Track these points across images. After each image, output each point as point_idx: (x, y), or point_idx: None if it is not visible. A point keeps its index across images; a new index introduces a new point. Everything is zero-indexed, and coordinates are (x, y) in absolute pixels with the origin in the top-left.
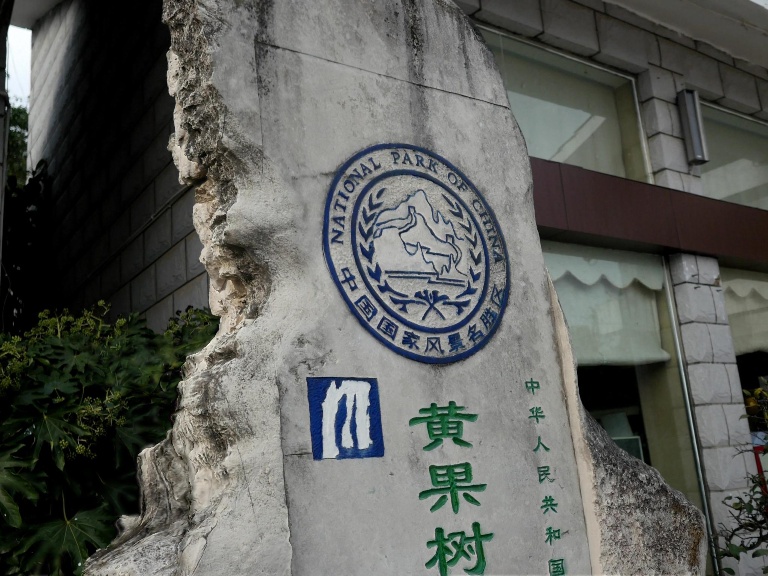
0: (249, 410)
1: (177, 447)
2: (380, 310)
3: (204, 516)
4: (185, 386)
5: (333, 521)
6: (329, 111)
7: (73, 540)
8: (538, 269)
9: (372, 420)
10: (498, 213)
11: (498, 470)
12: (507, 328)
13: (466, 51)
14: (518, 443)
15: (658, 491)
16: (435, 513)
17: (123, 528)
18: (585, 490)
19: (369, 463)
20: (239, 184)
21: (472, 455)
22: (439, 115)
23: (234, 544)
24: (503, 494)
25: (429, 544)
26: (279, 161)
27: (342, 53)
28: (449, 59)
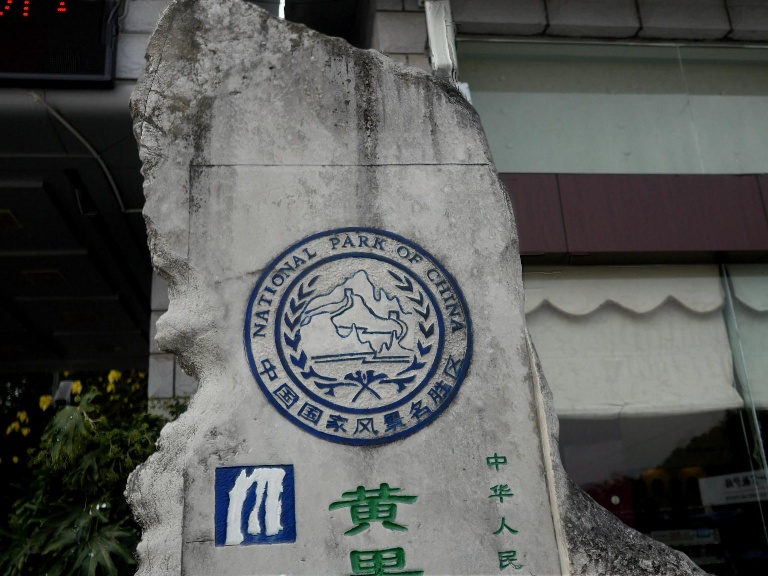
0: (157, 501)
1: None
2: (303, 396)
3: None
4: None
5: None
6: (262, 213)
7: None
8: (513, 332)
9: (284, 506)
10: (461, 279)
11: (441, 556)
12: (464, 401)
13: (434, 118)
14: (471, 526)
15: None
16: None
17: None
18: None
19: (277, 549)
20: (170, 295)
21: (407, 540)
22: (391, 191)
23: None
24: None
25: None
26: (203, 269)
27: (282, 155)
28: (410, 131)
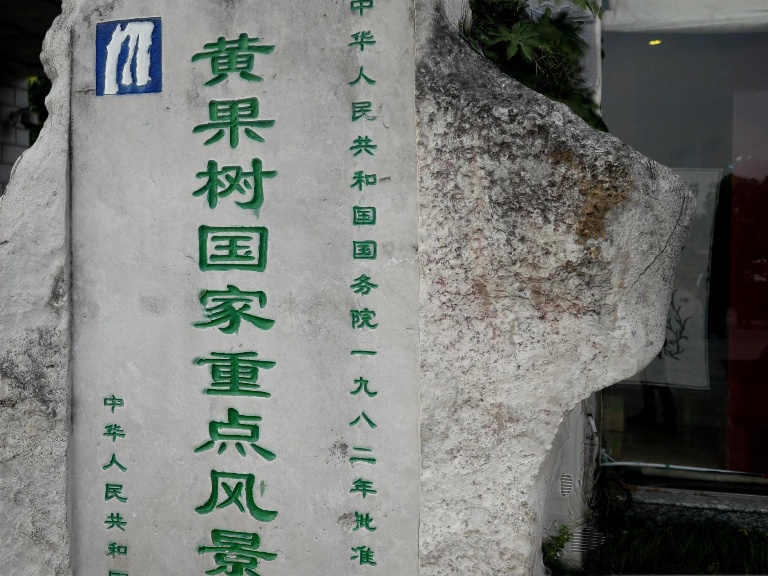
0: (55, 56)
1: None
2: None
3: None
4: None
5: (110, 147)
6: None
7: None
8: None
9: (153, 58)
10: None
11: (294, 105)
12: None
13: None
14: (327, 75)
15: (532, 132)
16: (210, 146)
17: None
18: None
19: (146, 98)
20: None
21: (262, 89)
22: None
23: (34, 159)
24: (296, 131)
25: (200, 174)
26: None
27: None
28: None
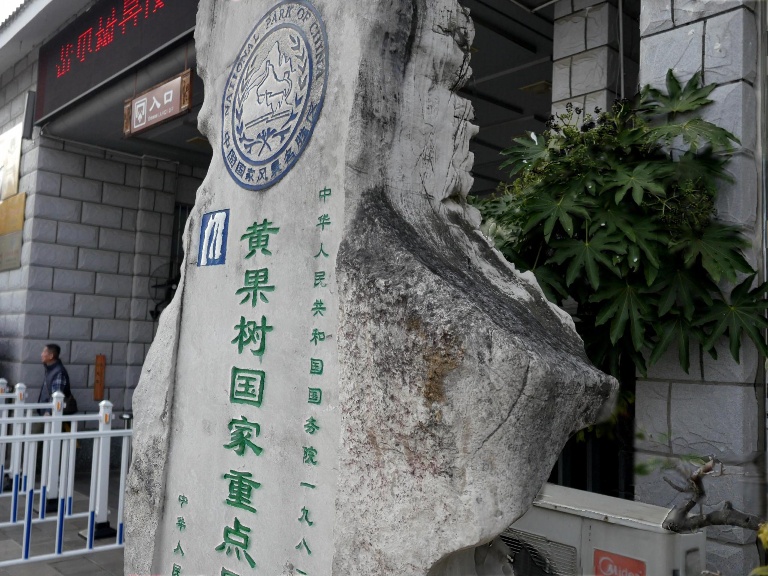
0: None
1: None
2: (239, 157)
3: None
4: None
5: None
6: (239, 14)
7: None
8: (353, 66)
9: (223, 239)
10: (329, 24)
11: (285, 274)
12: (314, 142)
13: None
14: (303, 250)
15: (399, 301)
16: (243, 305)
17: None
18: None
19: None
20: None
21: None
22: None
23: None
24: (285, 295)
25: None
26: None
27: None
28: None
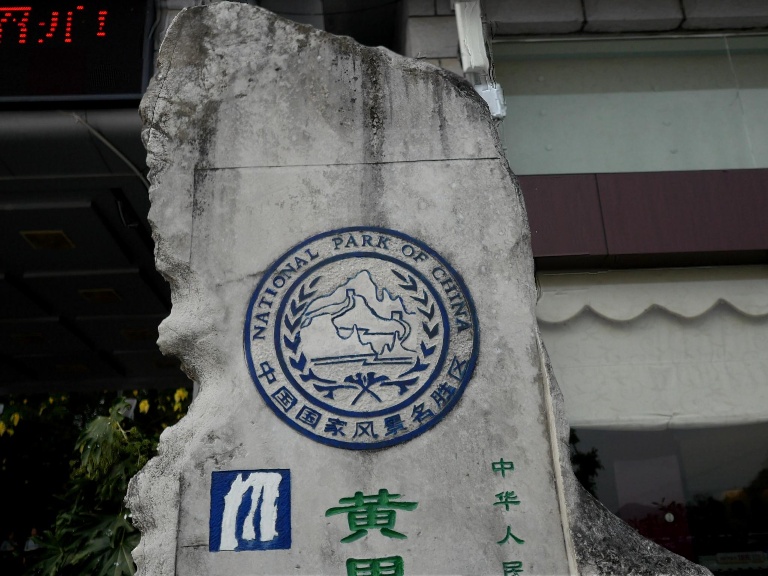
0: (154, 505)
1: None
2: (301, 399)
3: None
4: None
5: None
6: (265, 214)
7: None
8: (522, 331)
9: (280, 511)
10: (468, 277)
11: (441, 565)
12: (469, 403)
13: (443, 112)
14: (474, 534)
15: None
16: None
17: None
18: None
19: (271, 555)
20: (173, 299)
21: (406, 548)
22: (397, 188)
23: None
24: None
25: None
26: (205, 272)
27: (286, 156)
28: (418, 127)
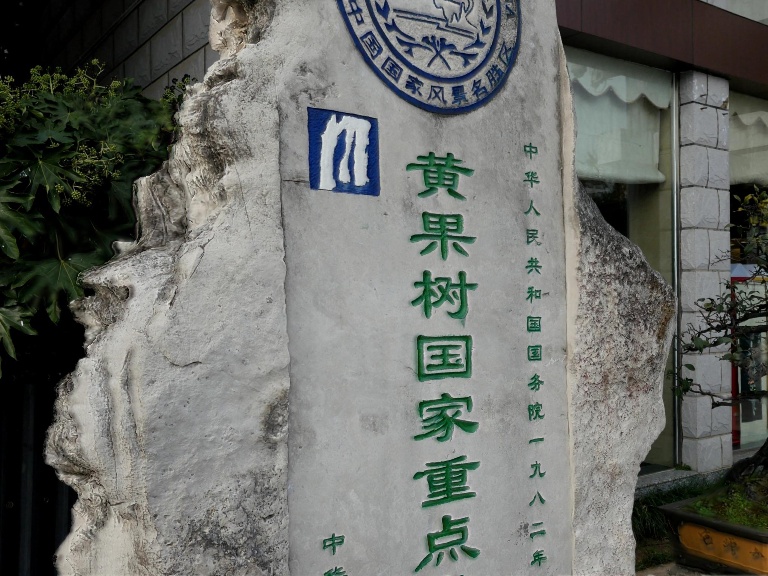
0: (248, 131)
1: (173, 175)
2: (385, 50)
3: (201, 232)
4: (183, 106)
5: (326, 249)
6: None
7: (67, 278)
8: (550, 33)
9: (370, 159)
10: None
11: (489, 226)
12: (512, 89)
13: None
14: (511, 204)
15: (639, 266)
16: (425, 257)
17: (119, 250)
18: (570, 257)
19: (365, 200)
20: None
21: (465, 208)
22: None
23: (230, 256)
24: (491, 249)
25: (417, 284)
26: None
27: None
28: None
